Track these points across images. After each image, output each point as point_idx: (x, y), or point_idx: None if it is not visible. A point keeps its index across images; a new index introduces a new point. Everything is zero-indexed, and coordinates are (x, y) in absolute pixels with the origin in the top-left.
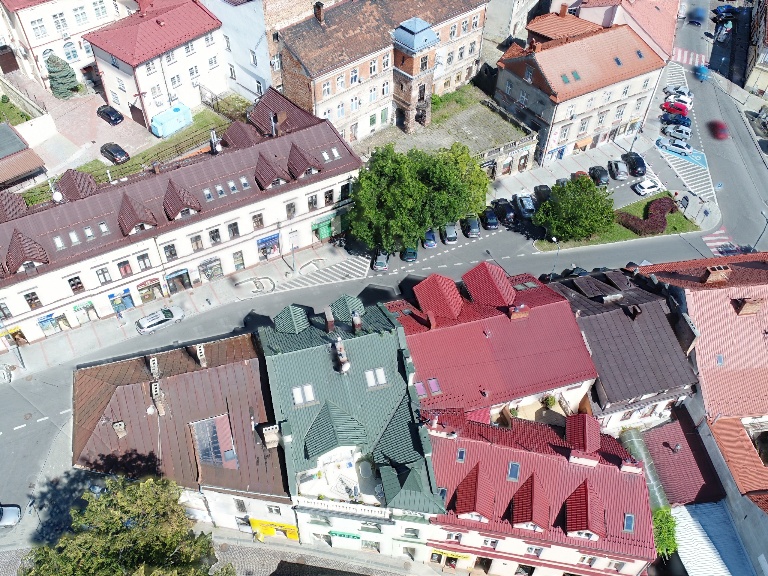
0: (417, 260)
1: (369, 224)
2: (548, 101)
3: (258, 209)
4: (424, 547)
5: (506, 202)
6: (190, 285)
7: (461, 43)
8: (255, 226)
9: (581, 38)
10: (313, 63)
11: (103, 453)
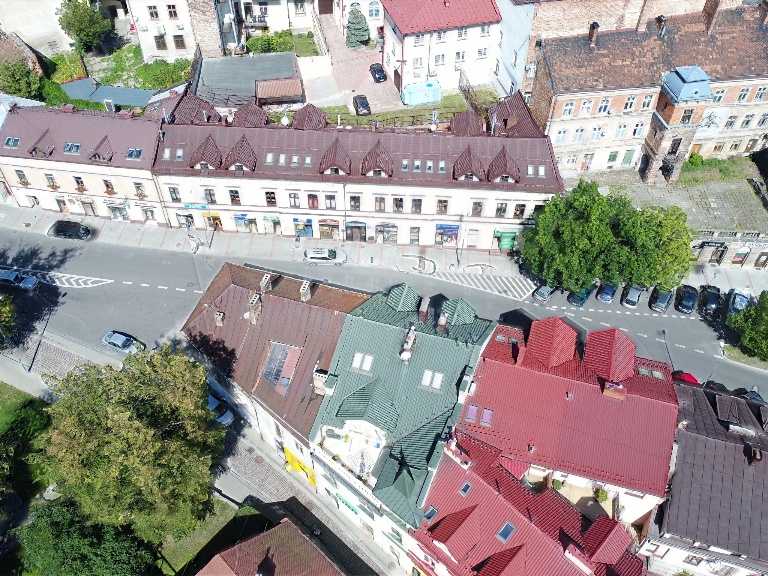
0: (583, 307)
1: (540, 250)
2: None
3: (445, 195)
4: (406, 555)
5: (716, 291)
6: (365, 239)
7: (750, 110)
8: (439, 210)
9: None
10: (563, 79)
11: (203, 332)
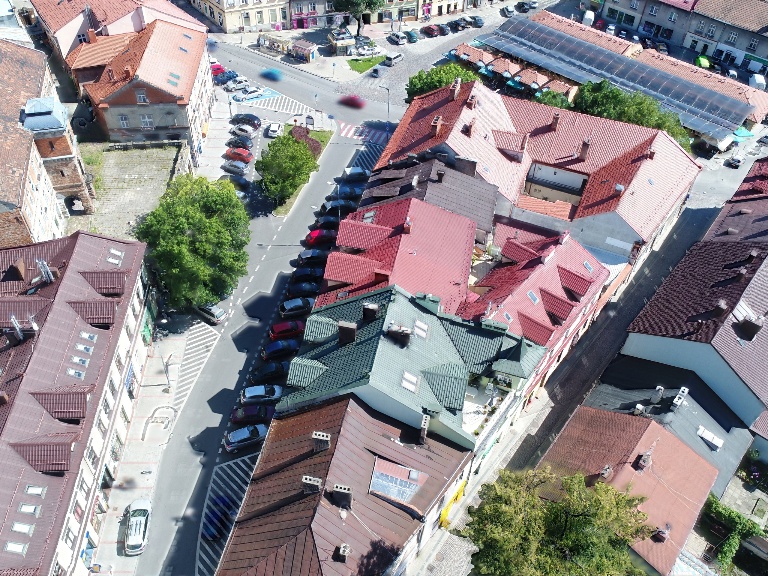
0: None
1: (203, 283)
2: (176, 108)
3: (115, 351)
4: None
5: None
6: (111, 481)
7: None
8: None
9: (142, 47)
10: (4, 195)
11: None
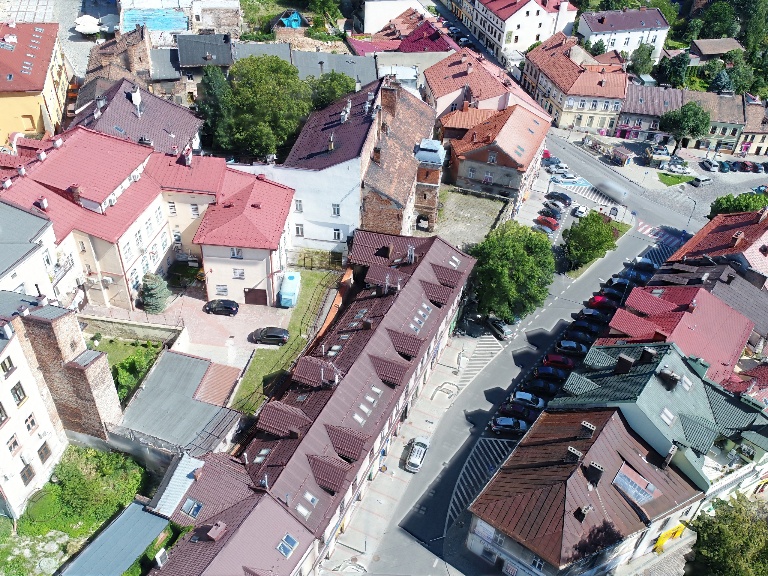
0: None
1: (508, 302)
2: (515, 173)
3: None
4: None
5: None
6: (404, 417)
7: None
8: None
9: (502, 122)
10: (397, 197)
11: (575, 543)
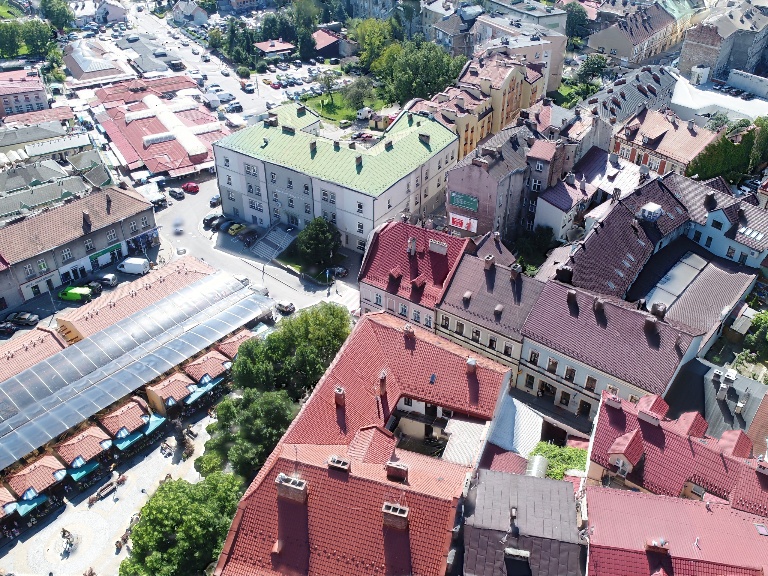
0: None
1: None
2: None
3: None
4: None
5: None
6: None
7: None
8: None
9: None
10: None
11: None
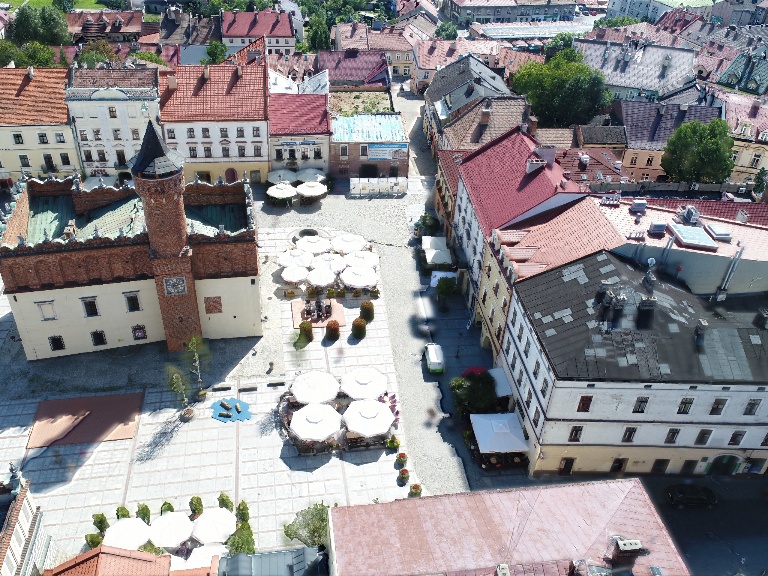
0: None
1: None
2: None
3: None
4: None
5: None
6: None
7: None
8: None
9: (524, 55)
10: None
11: None
